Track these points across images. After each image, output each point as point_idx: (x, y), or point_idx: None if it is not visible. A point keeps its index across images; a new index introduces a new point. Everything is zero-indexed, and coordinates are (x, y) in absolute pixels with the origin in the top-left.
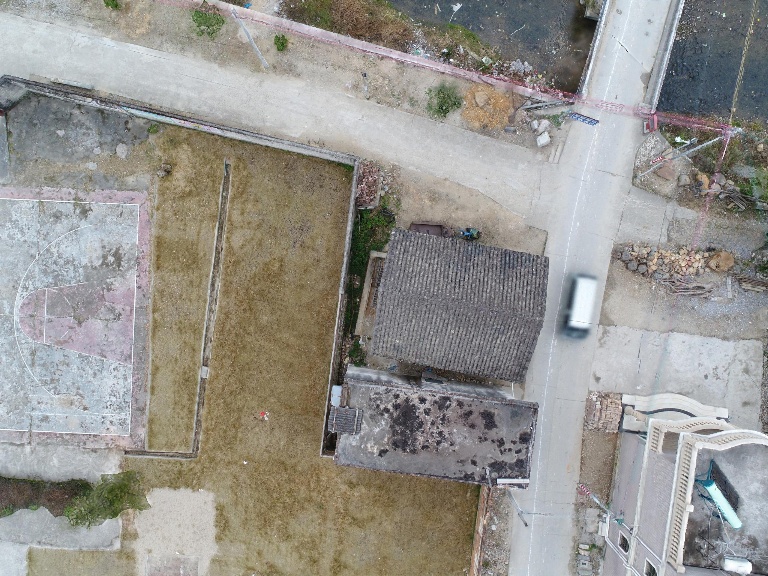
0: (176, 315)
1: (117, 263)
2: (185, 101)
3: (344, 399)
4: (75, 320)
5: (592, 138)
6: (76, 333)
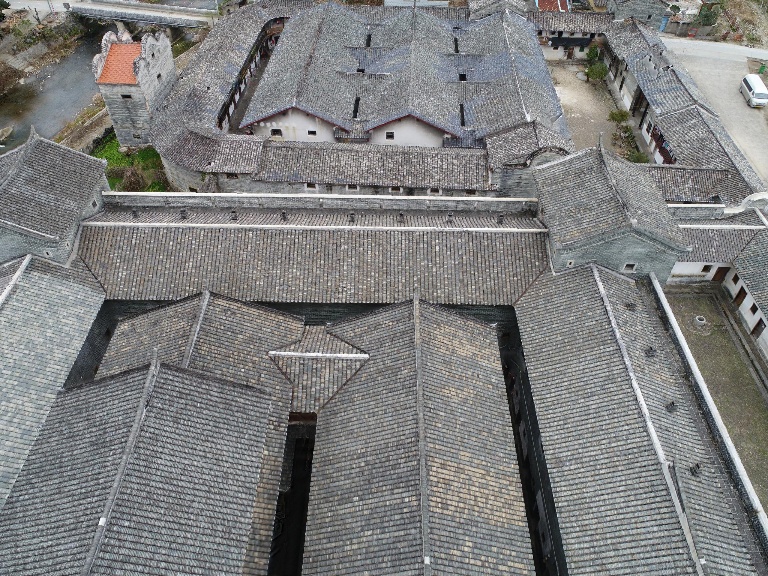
0: None
1: None
2: None
3: None
4: None
5: (73, 5)
6: None
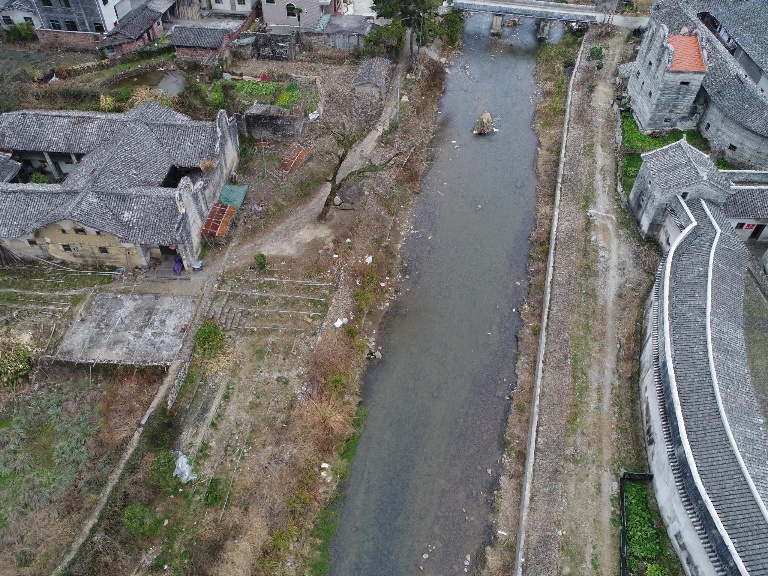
0: None
1: None
2: None
3: None
4: None
5: None
6: None
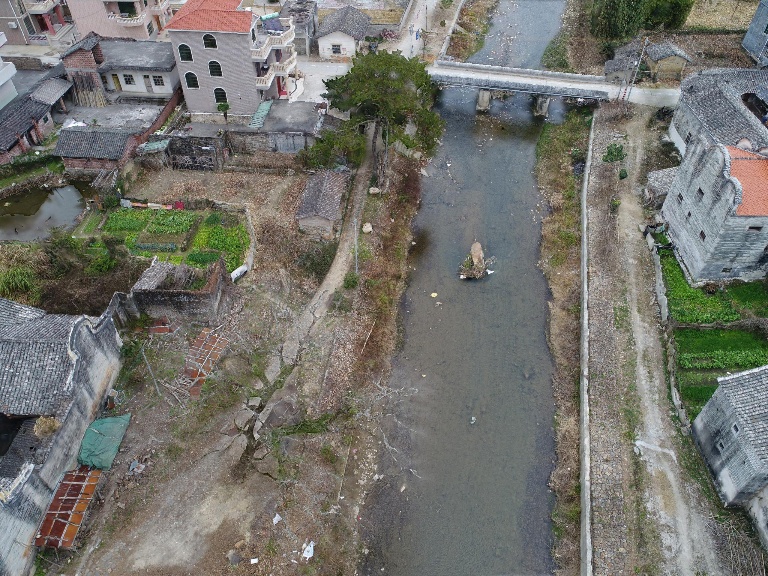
0: None
1: (358, 5)
2: None
3: (310, 1)
4: (337, 0)
5: None
6: (332, 0)
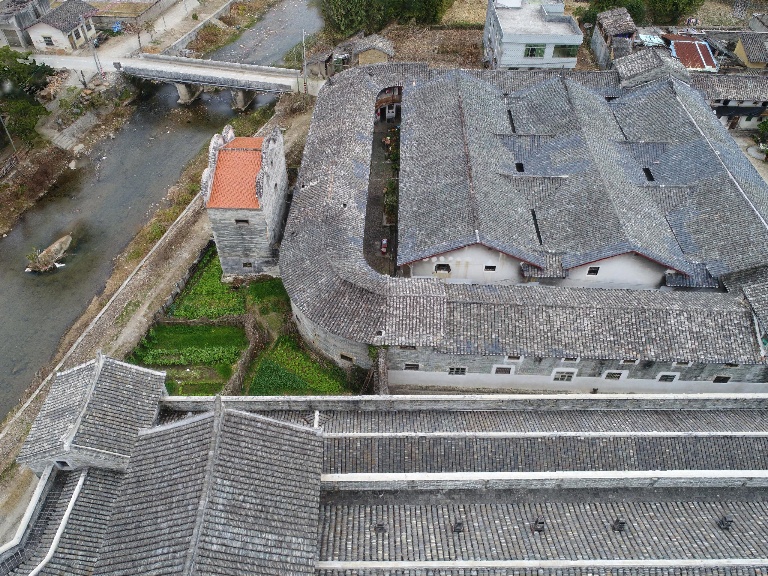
0: (102, 6)
1: None
2: (181, 5)
3: None
4: None
5: None
6: None
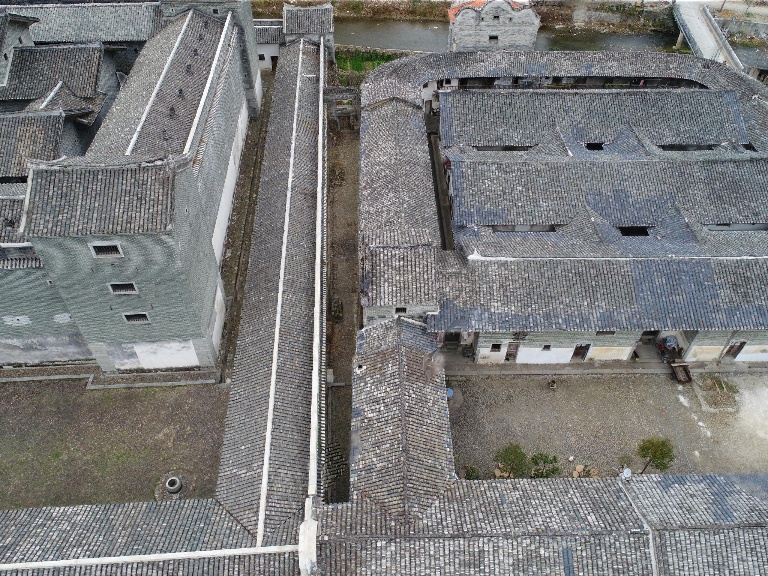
0: None
1: None
2: None
3: None
4: None
5: None
6: None
